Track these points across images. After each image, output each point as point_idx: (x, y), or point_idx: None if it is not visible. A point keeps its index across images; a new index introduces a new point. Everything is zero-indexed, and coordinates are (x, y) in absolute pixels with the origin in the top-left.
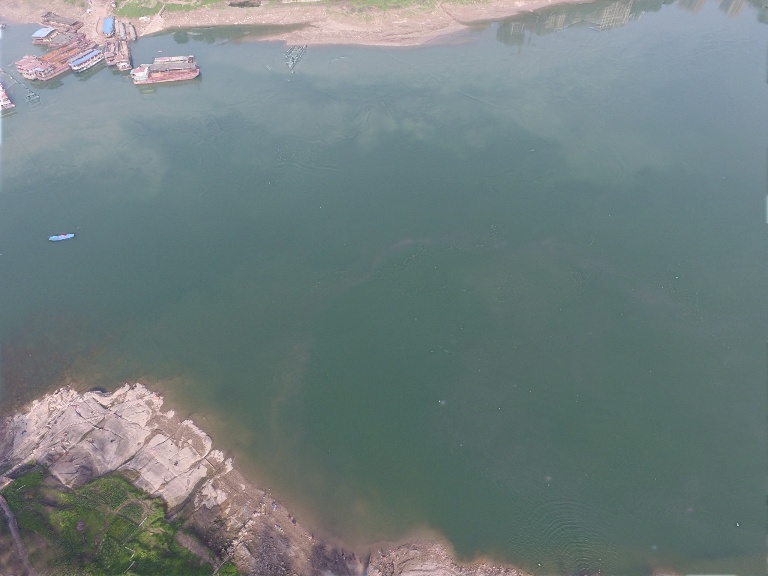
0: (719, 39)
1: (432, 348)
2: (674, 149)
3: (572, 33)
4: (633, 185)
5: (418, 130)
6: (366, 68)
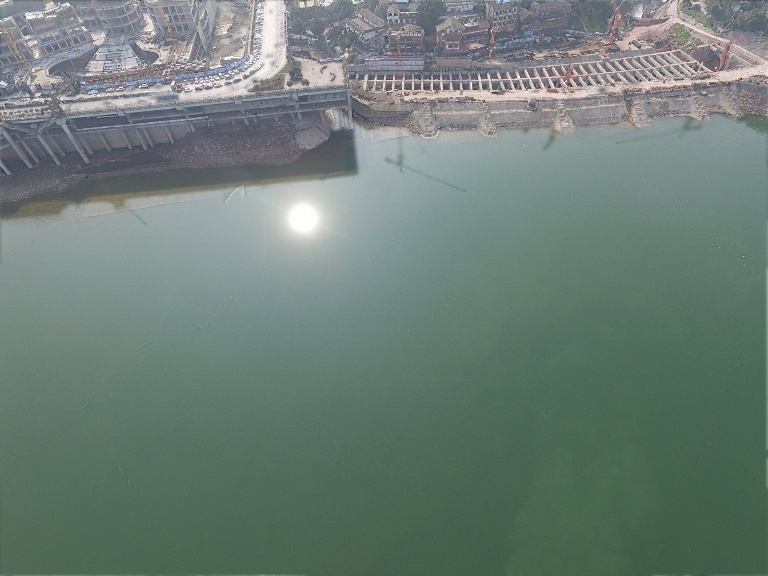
0: None
1: None
2: None
3: None
4: None
5: None
6: None
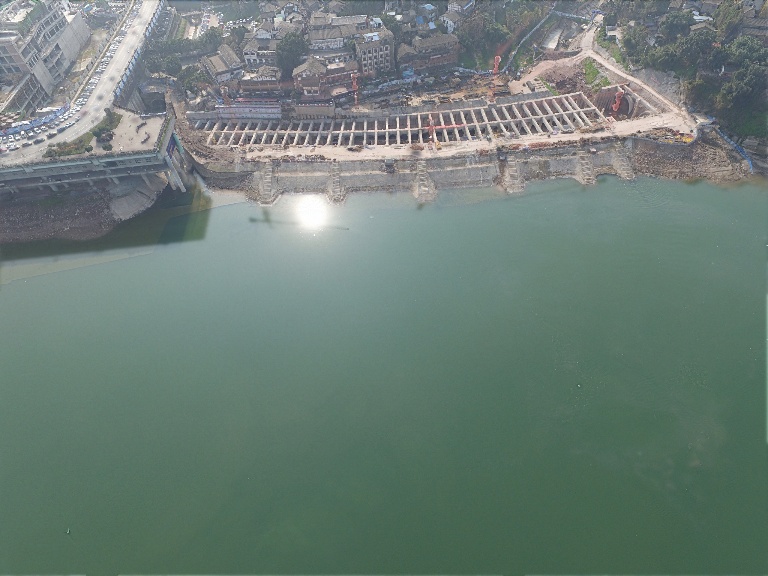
0: None
1: None
2: None
3: None
4: None
5: None
6: None
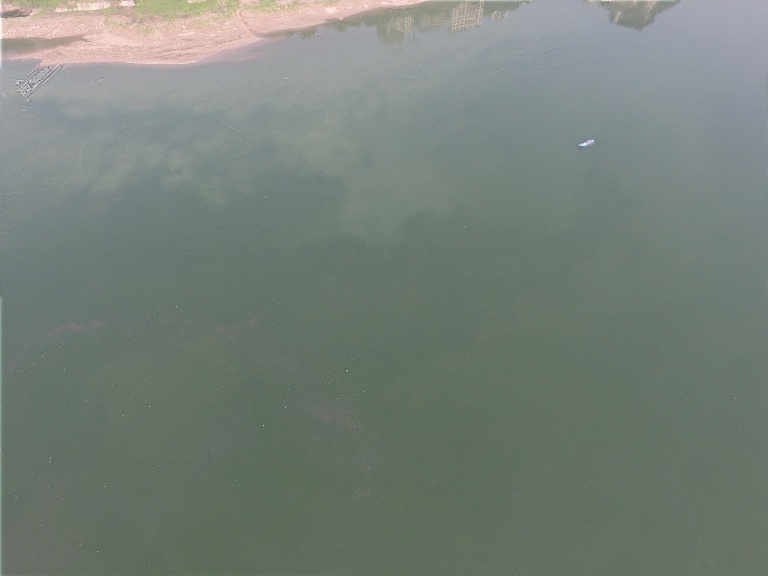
0: (532, 50)
1: (2, 493)
2: (425, 191)
3: (375, 45)
4: (358, 241)
5: (144, 174)
6: (119, 94)
